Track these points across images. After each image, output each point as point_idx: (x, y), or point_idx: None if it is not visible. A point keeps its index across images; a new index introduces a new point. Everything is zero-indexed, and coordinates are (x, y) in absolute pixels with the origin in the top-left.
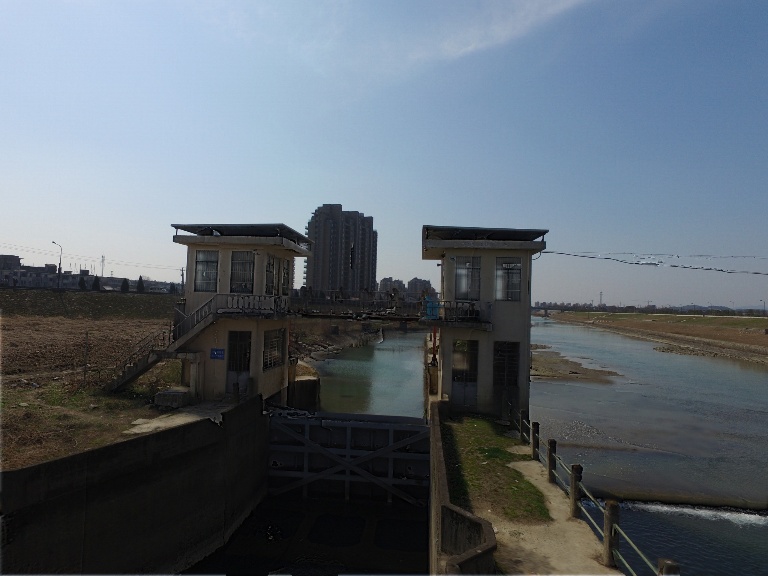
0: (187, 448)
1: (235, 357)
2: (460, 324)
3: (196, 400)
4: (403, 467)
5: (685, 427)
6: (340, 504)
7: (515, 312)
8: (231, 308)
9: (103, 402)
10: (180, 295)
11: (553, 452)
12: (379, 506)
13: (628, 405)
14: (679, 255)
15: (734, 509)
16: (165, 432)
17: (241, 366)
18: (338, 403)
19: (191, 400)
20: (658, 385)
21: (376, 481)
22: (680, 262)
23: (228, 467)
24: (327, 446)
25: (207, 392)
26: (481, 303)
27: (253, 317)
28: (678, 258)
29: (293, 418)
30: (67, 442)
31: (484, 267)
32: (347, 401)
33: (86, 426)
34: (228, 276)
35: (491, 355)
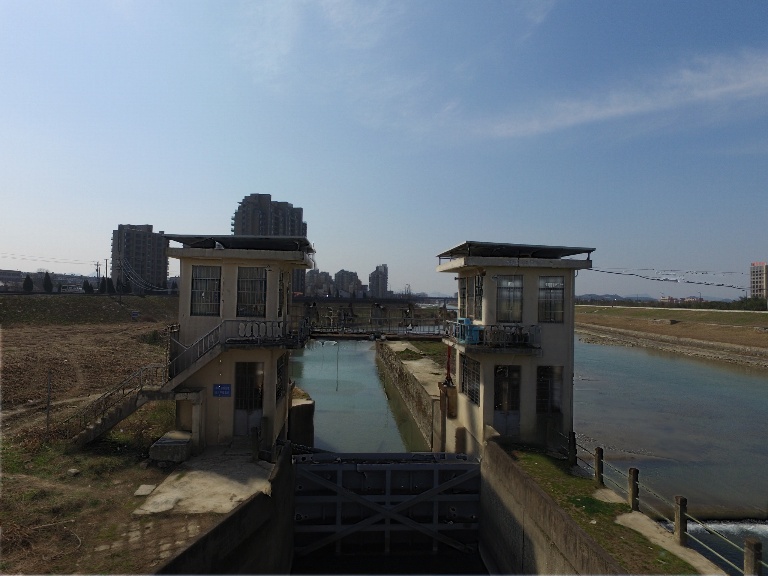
0: (243, 537)
1: (244, 393)
2: (509, 350)
3: (200, 449)
4: (446, 509)
5: (658, 427)
6: (380, 558)
7: (558, 334)
8: (244, 337)
9: (83, 463)
10: (174, 321)
11: (684, 511)
12: (424, 556)
13: (595, 405)
14: (697, 271)
15: (756, 521)
16: (223, 524)
17: (252, 403)
18: (317, 420)
19: (194, 449)
20: (609, 381)
21: (420, 529)
22: (697, 278)
23: (277, 545)
24: (361, 492)
25: (209, 436)
26: (530, 327)
27: (272, 347)
28: (696, 274)
29: (323, 464)
30: (65, 539)
31: (526, 286)
32: (325, 417)
33: (77, 506)
34: (234, 297)
35: (534, 381)
